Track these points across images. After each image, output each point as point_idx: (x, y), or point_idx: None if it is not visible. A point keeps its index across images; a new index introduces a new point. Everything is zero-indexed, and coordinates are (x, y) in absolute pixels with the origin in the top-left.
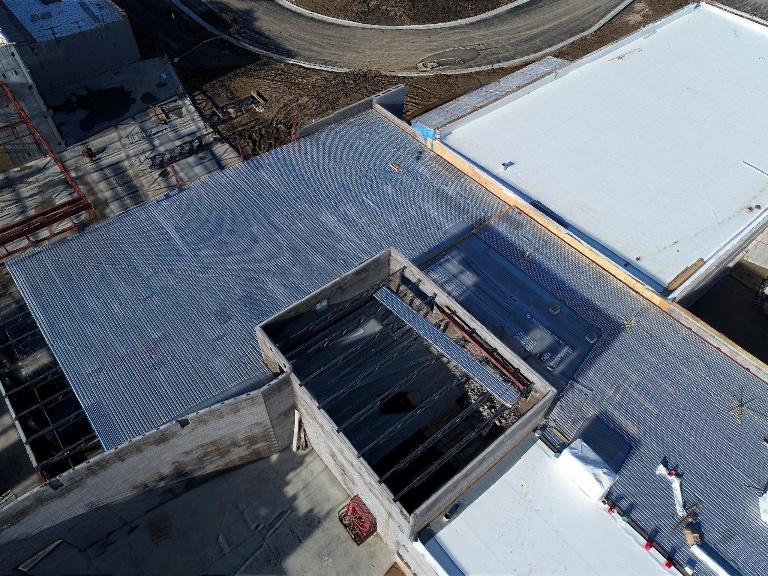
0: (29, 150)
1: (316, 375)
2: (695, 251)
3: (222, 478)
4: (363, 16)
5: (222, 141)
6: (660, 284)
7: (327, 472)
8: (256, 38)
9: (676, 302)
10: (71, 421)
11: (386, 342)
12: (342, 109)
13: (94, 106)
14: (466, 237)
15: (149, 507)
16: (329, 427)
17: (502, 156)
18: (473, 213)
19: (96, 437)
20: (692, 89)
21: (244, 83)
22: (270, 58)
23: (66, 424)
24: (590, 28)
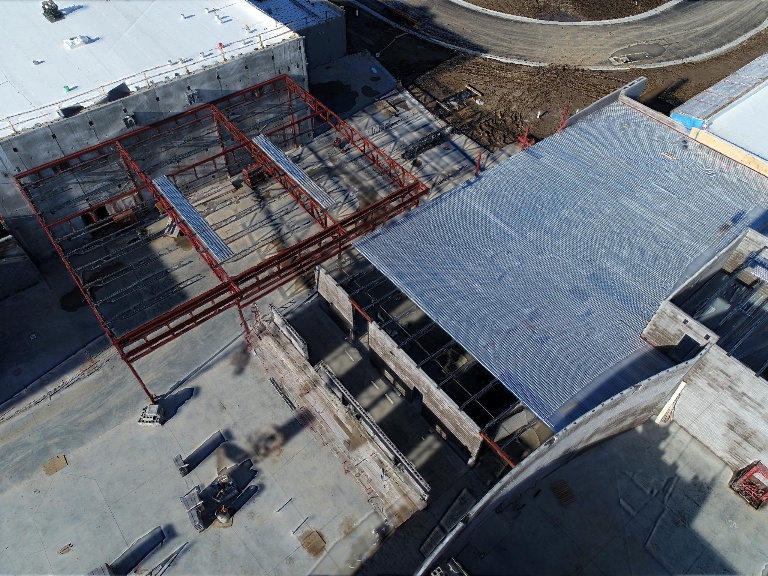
0: None
1: None
2: None
3: (599, 447)
4: (536, 12)
5: (458, 132)
6: None
7: (695, 442)
8: (443, 34)
9: None
10: (486, 390)
11: (742, 319)
12: (599, 100)
13: (321, 99)
14: None
15: (548, 473)
16: (766, 394)
17: None
18: (764, 199)
19: (515, 405)
20: None
21: (453, 77)
22: (466, 53)
23: (482, 393)
24: (761, 23)
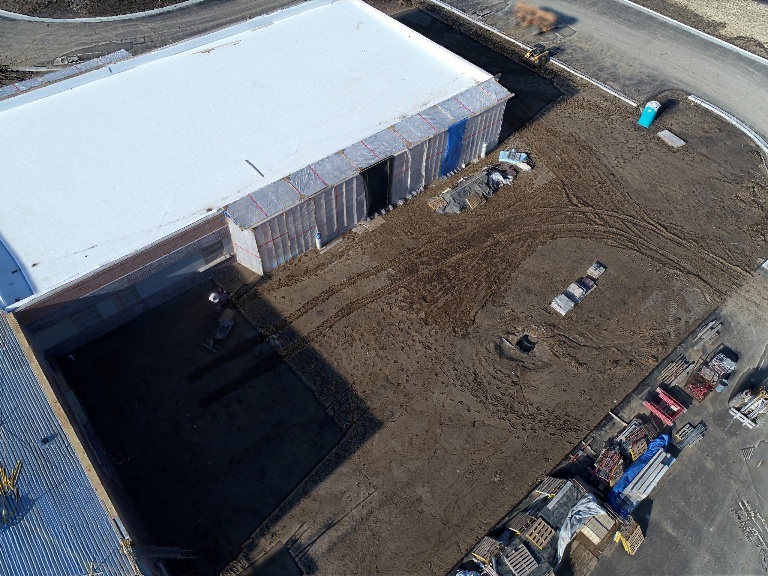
0: None
1: None
2: (105, 256)
3: None
4: (39, 9)
5: None
6: (32, 292)
7: None
8: None
9: (14, 312)
10: None
11: None
12: None
13: None
14: None
15: None
16: None
17: None
18: None
19: None
20: (258, 84)
21: None
22: None
23: None
24: None
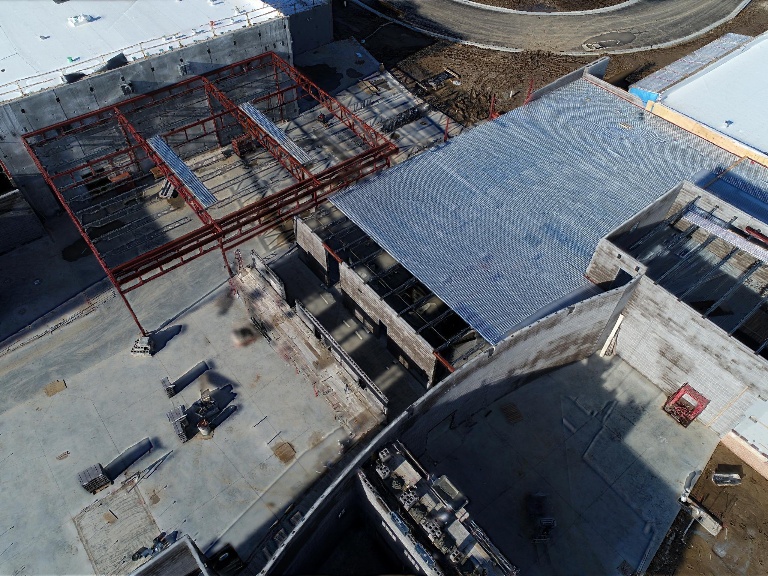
0: (274, 115)
1: (665, 276)
2: None
3: (547, 376)
4: (516, 4)
5: (435, 109)
6: None
7: (635, 373)
8: (426, 23)
9: None
10: (441, 319)
11: None
12: (563, 77)
13: None
14: (714, 181)
15: (498, 396)
16: (687, 317)
17: (720, 116)
18: (710, 163)
19: (467, 331)
20: None
21: (433, 61)
22: (447, 40)
23: (438, 321)
24: (729, 14)
